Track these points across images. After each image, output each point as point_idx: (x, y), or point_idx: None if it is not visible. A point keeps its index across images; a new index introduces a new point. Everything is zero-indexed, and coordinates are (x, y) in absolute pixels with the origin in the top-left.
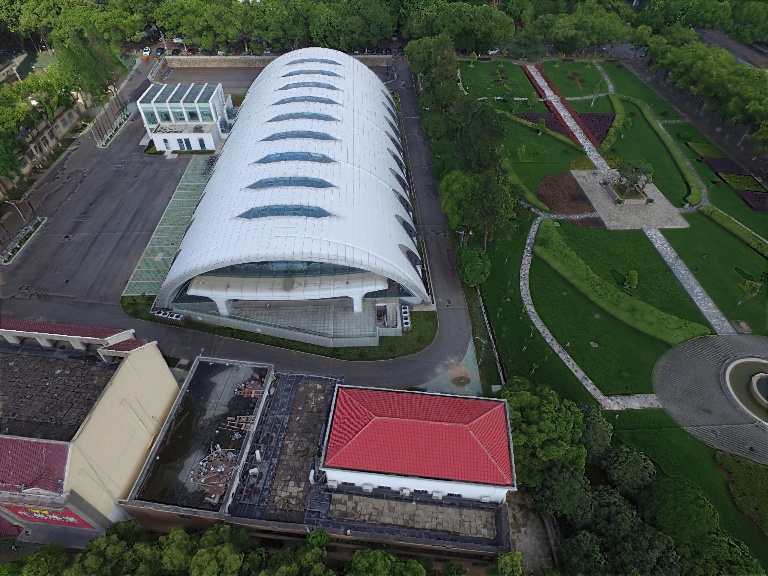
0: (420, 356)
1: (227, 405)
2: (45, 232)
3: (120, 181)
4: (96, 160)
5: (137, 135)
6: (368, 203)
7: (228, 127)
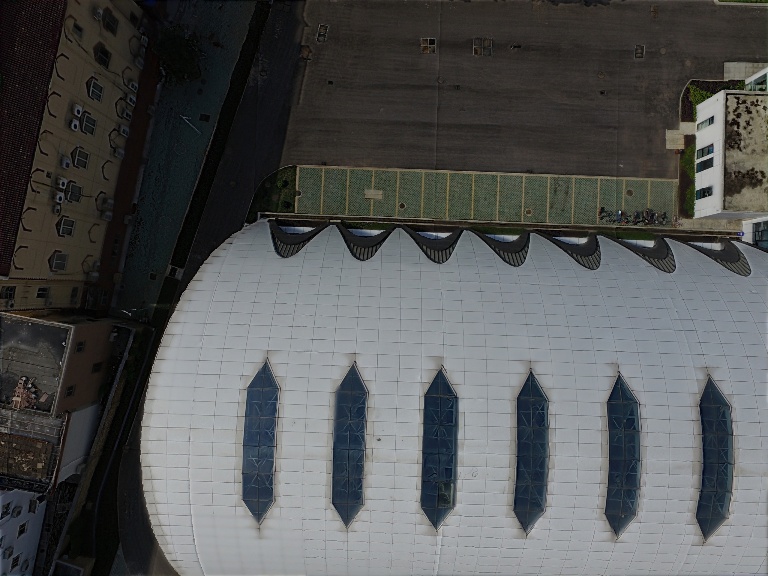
0: (162, 557)
1: (8, 371)
2: (446, 5)
3: (588, 70)
4: (667, 1)
5: (767, 47)
6: (334, 568)
7: (767, 237)
